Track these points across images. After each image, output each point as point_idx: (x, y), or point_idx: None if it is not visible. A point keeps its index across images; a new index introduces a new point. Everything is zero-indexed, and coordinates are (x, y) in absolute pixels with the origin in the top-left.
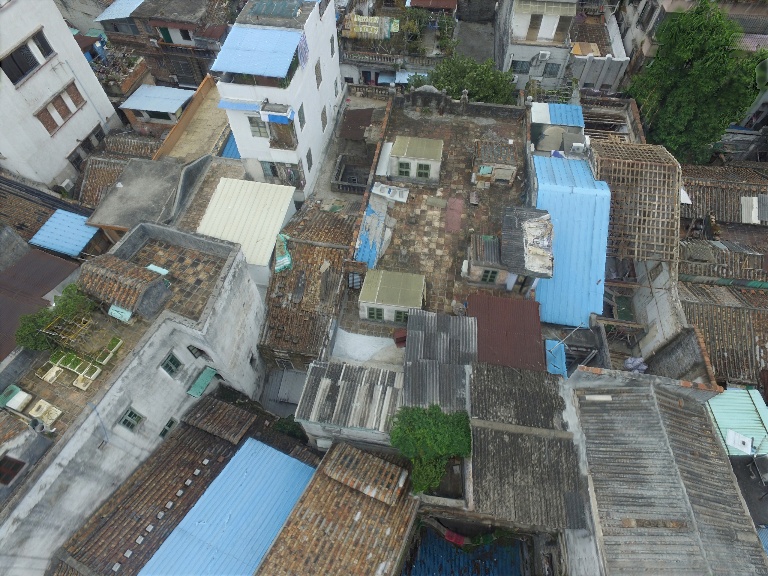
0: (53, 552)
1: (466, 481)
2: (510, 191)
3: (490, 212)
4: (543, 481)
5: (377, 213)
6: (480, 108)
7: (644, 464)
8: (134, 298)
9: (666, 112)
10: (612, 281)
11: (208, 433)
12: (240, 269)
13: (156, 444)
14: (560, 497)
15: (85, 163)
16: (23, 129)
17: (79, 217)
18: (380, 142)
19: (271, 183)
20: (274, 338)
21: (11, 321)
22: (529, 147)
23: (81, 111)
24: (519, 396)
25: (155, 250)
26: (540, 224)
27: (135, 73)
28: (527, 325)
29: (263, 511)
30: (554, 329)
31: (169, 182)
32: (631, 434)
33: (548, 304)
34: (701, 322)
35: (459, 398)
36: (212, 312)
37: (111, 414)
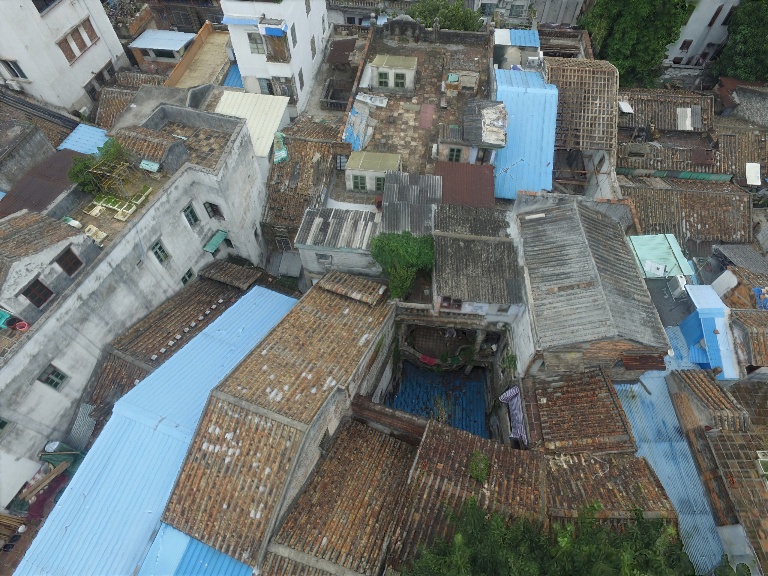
0: (103, 346)
1: (433, 292)
2: (475, 98)
3: (457, 114)
4: (490, 272)
5: (360, 114)
6: (450, 35)
7: (566, 253)
8: (161, 152)
9: (614, 39)
10: (566, 179)
11: (221, 283)
12: (246, 141)
13: (179, 287)
14: (503, 283)
15: (100, 93)
16: (47, 54)
17: (99, 130)
18: (362, 61)
19: (268, 96)
20: (274, 217)
21: (50, 198)
22: (492, 63)
23: (95, 46)
24: (473, 221)
25: (174, 129)
26: (496, 111)
27: (141, 18)
28: (483, 180)
29: (270, 327)
30: (511, 205)
31: (177, 103)
32: (558, 236)
33: (506, 184)
34: (637, 203)
35: (426, 226)
36: (225, 165)
37: (146, 238)
